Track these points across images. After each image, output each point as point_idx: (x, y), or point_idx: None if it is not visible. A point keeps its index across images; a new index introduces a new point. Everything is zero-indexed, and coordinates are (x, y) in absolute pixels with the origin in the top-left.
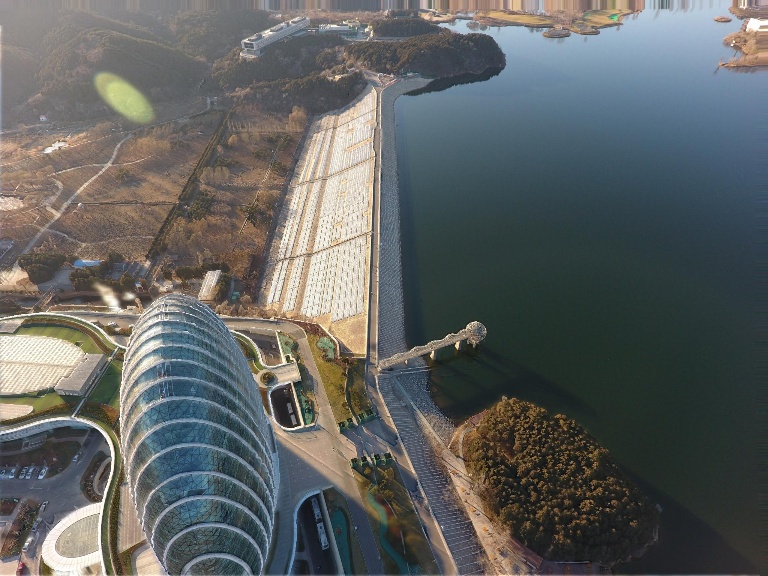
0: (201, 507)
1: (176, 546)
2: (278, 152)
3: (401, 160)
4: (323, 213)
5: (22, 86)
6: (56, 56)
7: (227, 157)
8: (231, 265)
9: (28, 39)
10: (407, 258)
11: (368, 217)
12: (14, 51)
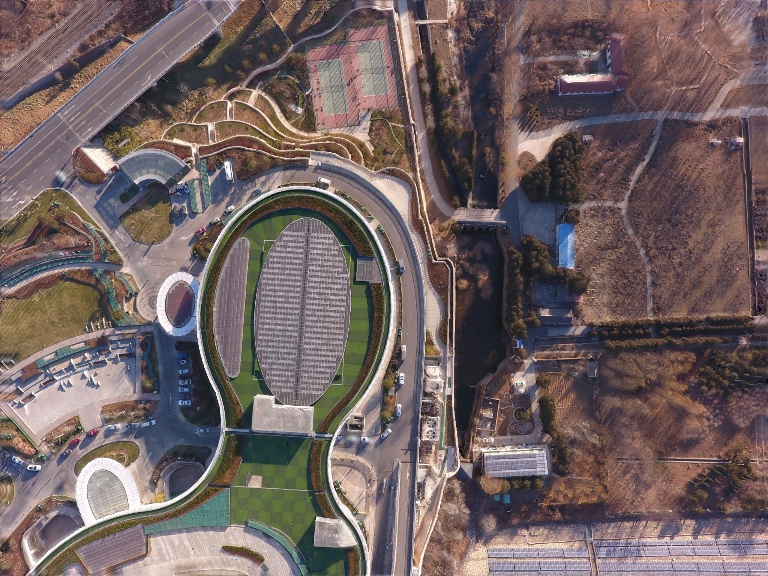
0: None
1: None
2: None
3: None
4: None
5: None
6: None
7: None
8: (574, 473)
9: None
10: None
11: None
12: None
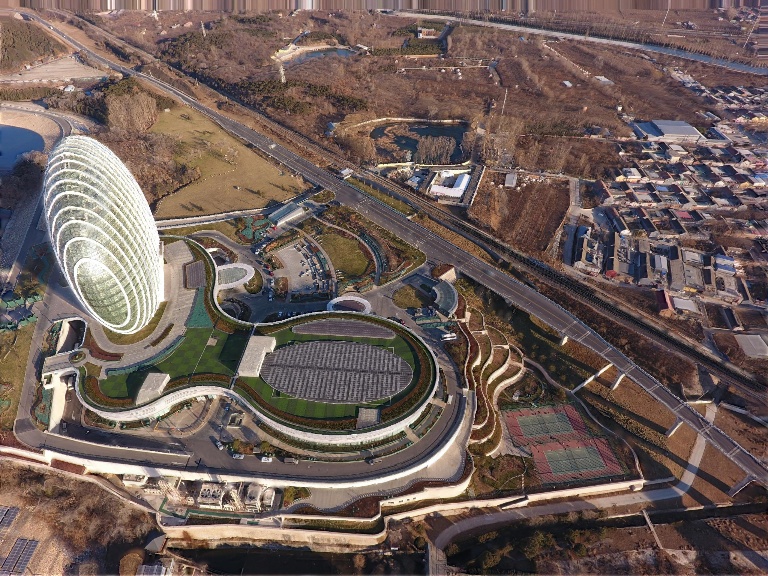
0: None
1: None
2: None
3: None
4: None
5: None
6: None
7: None
8: None
9: None
10: None
11: None
12: None
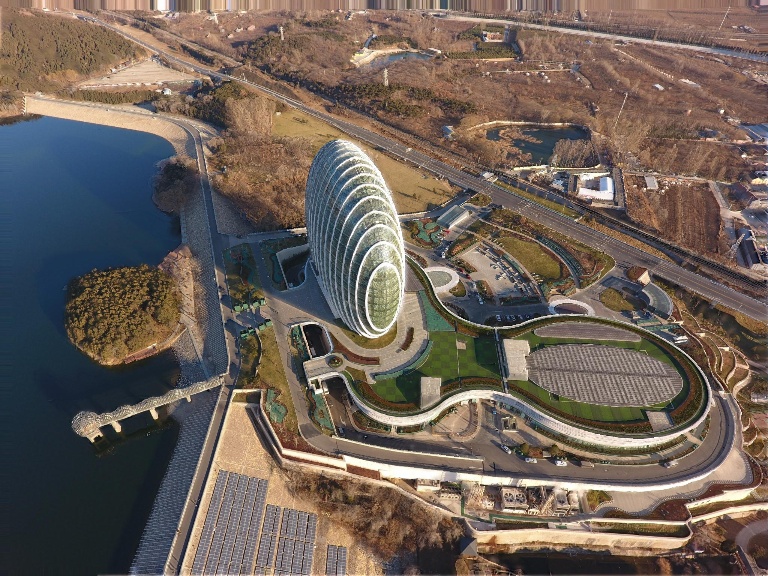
0: None
1: None
2: None
3: None
4: None
5: None
6: None
7: None
8: None
9: None
10: None
11: None
12: None
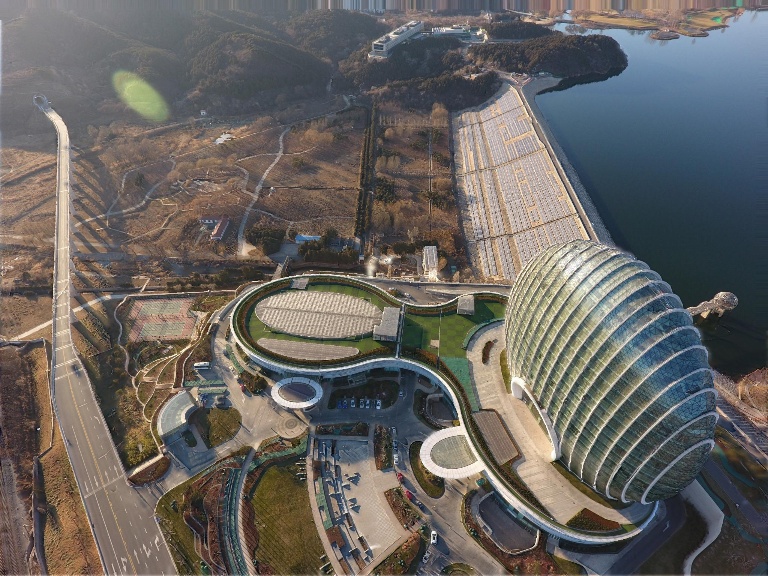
0: (712, 398)
1: (689, 430)
2: (432, 145)
3: (567, 152)
4: (507, 198)
5: (175, 84)
6: (204, 57)
7: (388, 148)
8: None
9: (169, 42)
10: (617, 238)
11: (566, 201)
12: (162, 53)
